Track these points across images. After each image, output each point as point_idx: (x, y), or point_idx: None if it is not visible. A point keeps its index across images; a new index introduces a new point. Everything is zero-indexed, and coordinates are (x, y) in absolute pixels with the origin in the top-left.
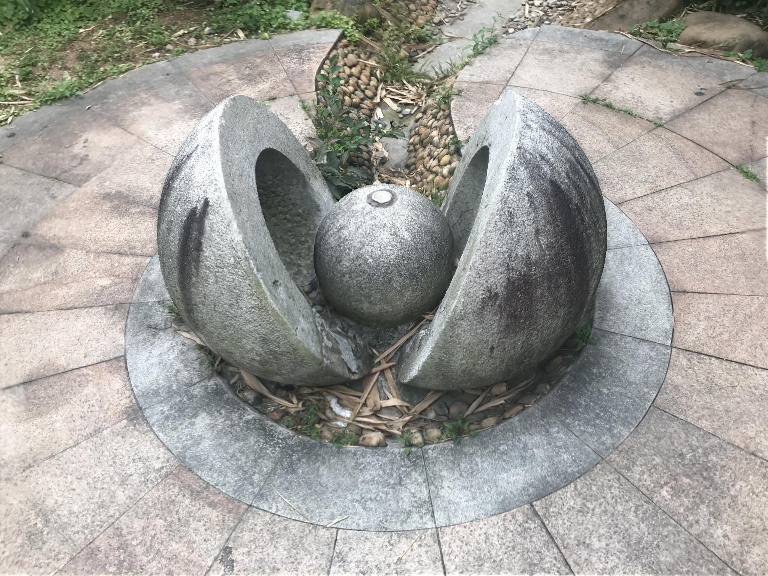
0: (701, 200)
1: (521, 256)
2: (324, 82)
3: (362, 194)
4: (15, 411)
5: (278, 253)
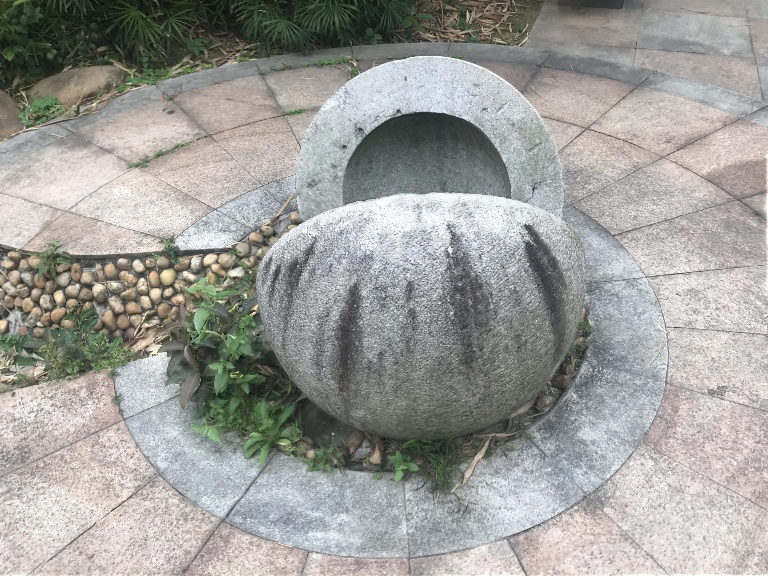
0: None
1: None
2: None
3: None
4: None
5: None
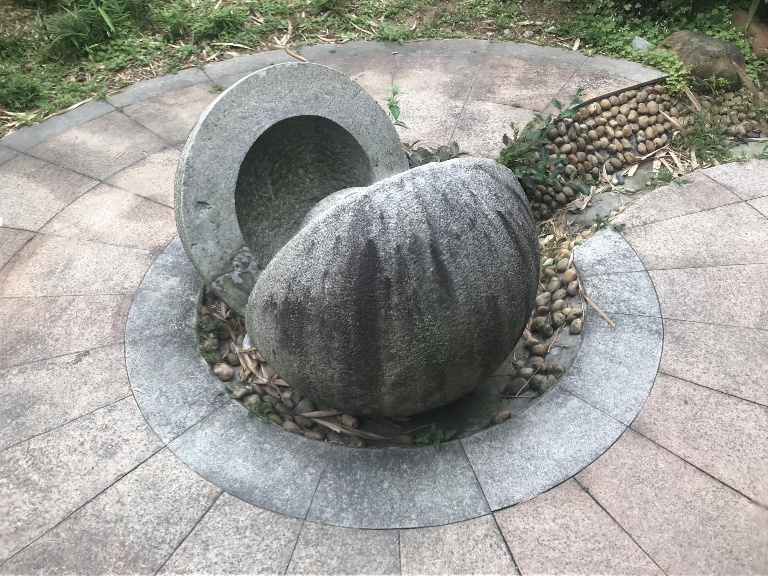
0: (764, 438)
1: (304, 285)
2: (584, 114)
3: (355, 190)
4: (124, 209)
5: None
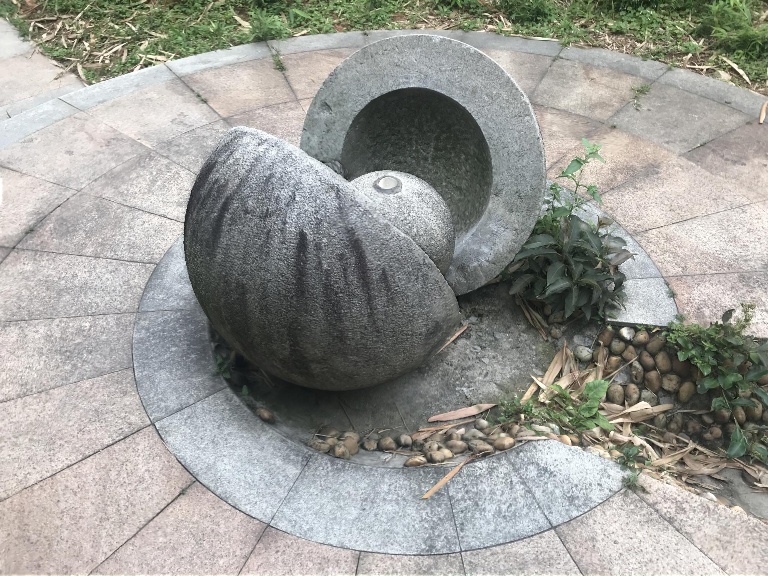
0: None
1: None
2: None
3: (406, 179)
4: None
5: (458, 203)
